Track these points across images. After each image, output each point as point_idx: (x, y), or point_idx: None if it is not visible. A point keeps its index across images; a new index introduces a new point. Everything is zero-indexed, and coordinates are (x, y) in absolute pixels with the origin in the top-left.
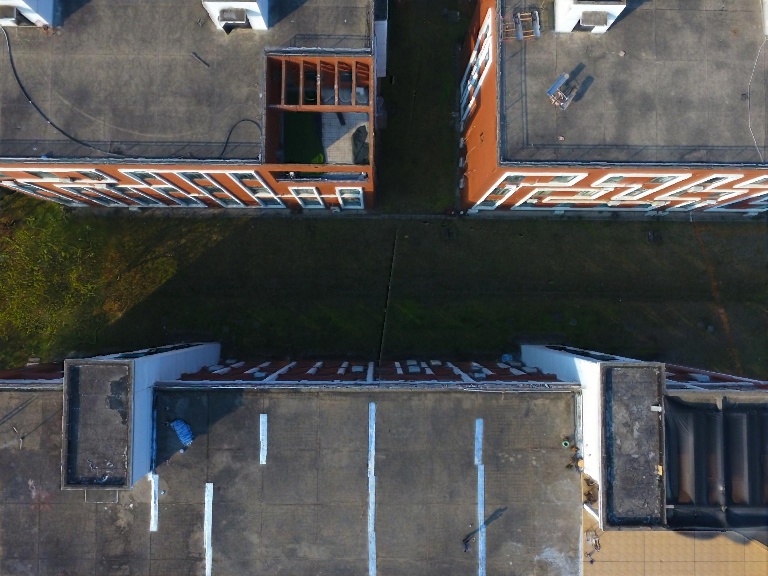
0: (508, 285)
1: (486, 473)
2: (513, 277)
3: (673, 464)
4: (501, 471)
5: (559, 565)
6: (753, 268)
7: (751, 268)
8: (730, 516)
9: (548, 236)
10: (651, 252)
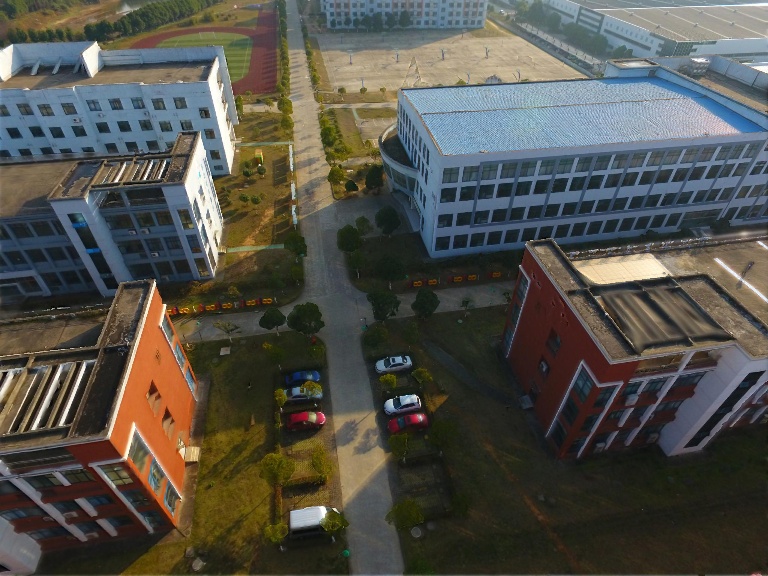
0: (759, 503)
1: (767, 303)
2: (763, 511)
3: (690, 307)
4: (759, 305)
5: (681, 270)
6: (529, 575)
7: (531, 575)
8: (635, 288)
9: (766, 566)
10: (648, 571)
